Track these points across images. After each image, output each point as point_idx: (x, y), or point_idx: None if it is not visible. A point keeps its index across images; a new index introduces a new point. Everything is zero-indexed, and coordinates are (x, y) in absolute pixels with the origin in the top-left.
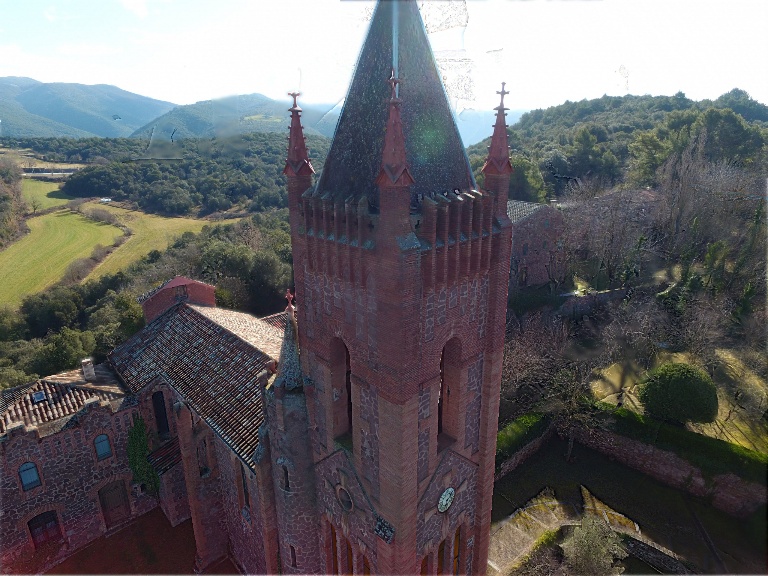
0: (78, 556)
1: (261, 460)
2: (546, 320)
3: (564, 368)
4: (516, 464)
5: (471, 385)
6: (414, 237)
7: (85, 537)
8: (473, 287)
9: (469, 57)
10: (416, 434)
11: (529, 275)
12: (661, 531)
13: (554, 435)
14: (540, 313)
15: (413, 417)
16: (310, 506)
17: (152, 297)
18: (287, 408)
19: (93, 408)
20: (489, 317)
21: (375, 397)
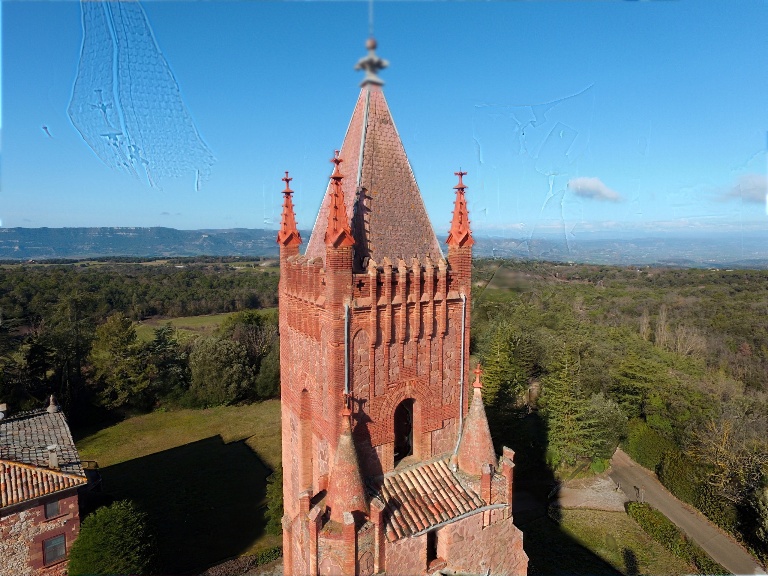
0: None
1: None
2: None
3: None
4: None
5: None
6: None
7: None
8: None
9: None
10: None
11: None
12: None
13: None
14: None
15: None
16: None
17: None
18: None
19: None
20: None
21: None
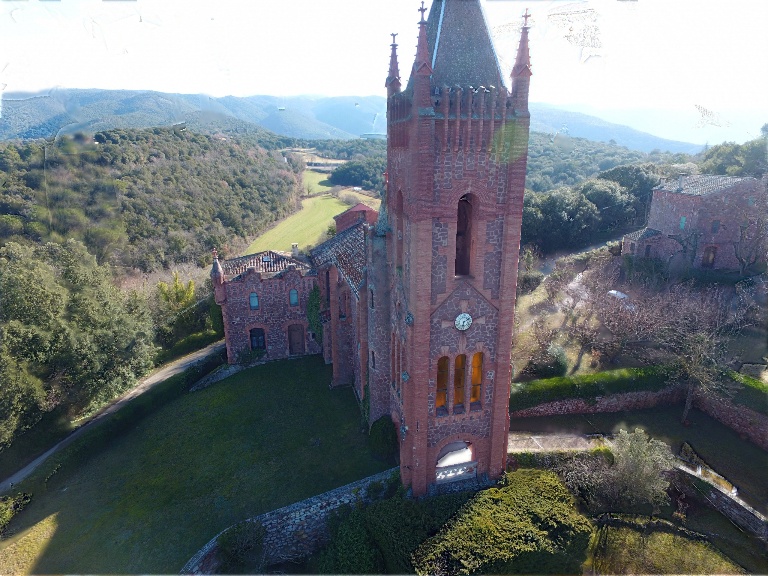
0: (272, 364)
1: (361, 288)
2: (699, 287)
3: (698, 329)
4: (619, 408)
5: (490, 239)
6: (432, 109)
7: (277, 354)
8: (492, 160)
9: (592, 7)
10: (430, 249)
11: (718, 256)
12: (766, 504)
13: (681, 402)
14: (694, 279)
15: (427, 235)
16: (385, 323)
17: (342, 215)
18: (375, 246)
19: (291, 269)
20: (508, 188)
21: (410, 224)
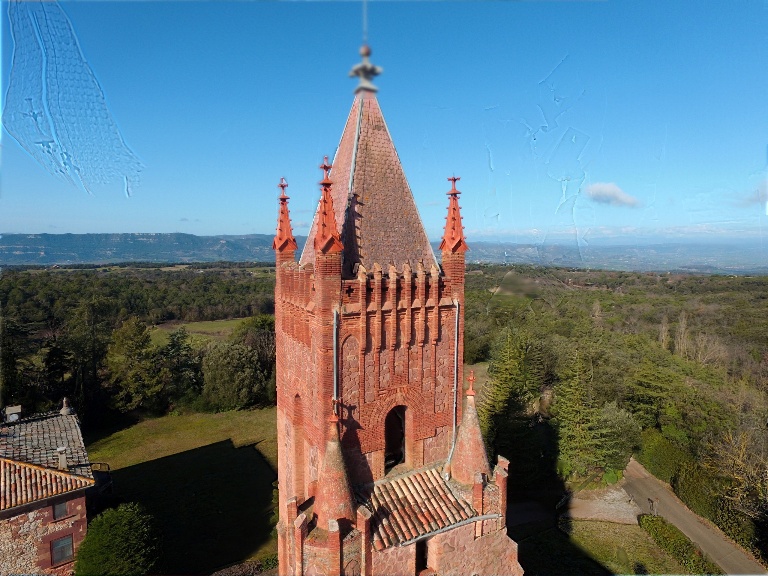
0: None
1: None
2: None
3: None
4: None
5: None
6: None
7: None
8: None
9: None
10: None
11: None
12: None
13: None
14: None
15: None
16: None
17: None
18: None
19: None
20: None
21: None
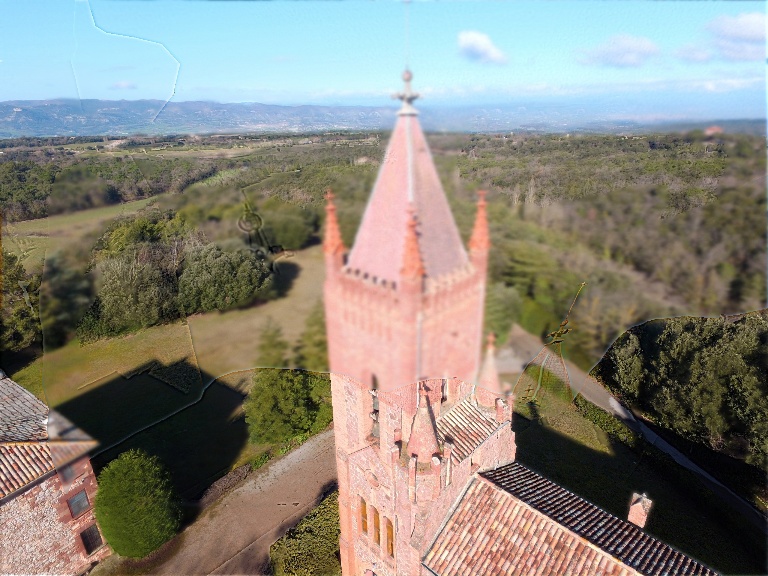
0: None
1: None
2: None
3: None
4: None
5: None
6: None
7: None
8: None
9: (149, 132)
10: None
11: None
12: None
13: None
14: None
15: None
16: None
17: None
18: None
19: None
20: None
21: None
